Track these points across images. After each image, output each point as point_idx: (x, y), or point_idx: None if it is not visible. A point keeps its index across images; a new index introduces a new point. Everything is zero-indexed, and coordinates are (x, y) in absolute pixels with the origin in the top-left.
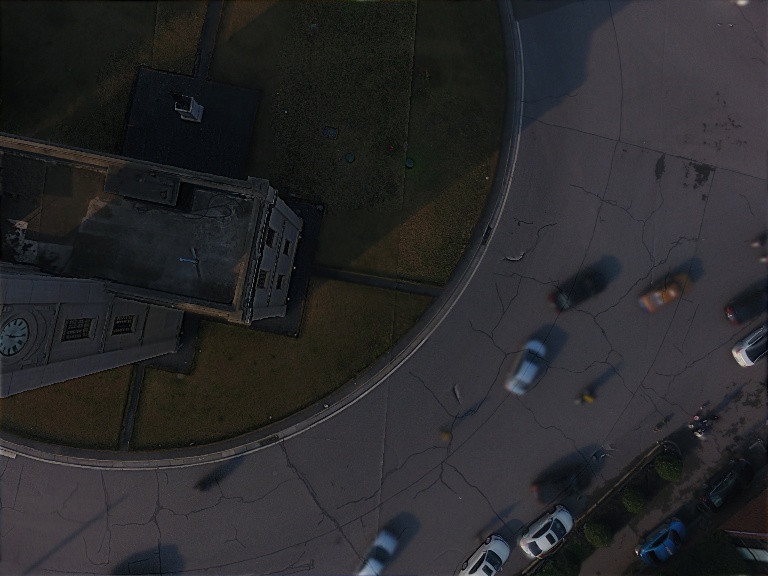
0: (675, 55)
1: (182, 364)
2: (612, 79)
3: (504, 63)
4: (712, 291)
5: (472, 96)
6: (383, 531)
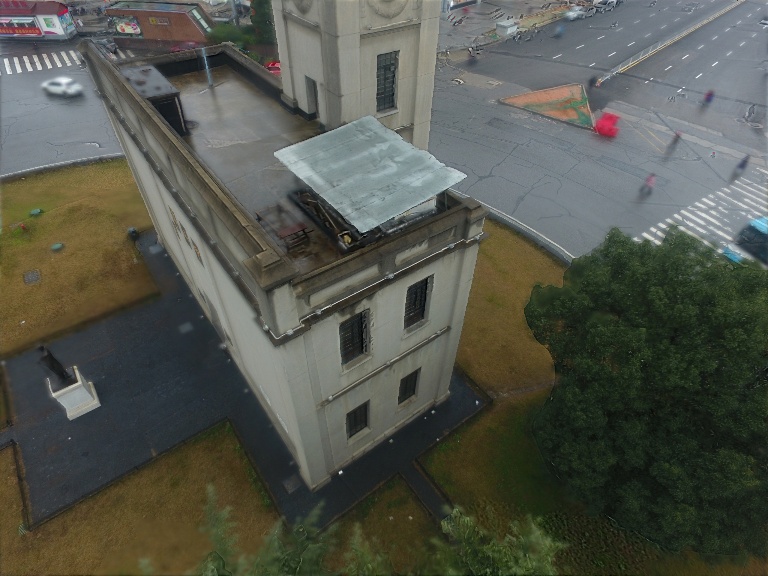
0: None
1: None
2: None
3: None
4: (56, 87)
5: None
6: None
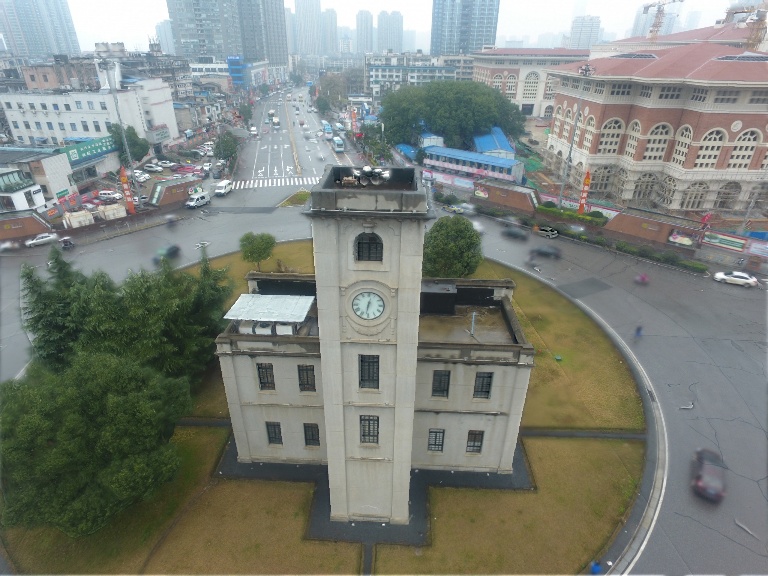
0: (684, 302)
1: (417, 537)
2: (657, 314)
3: (583, 313)
4: None
5: (575, 326)
6: None
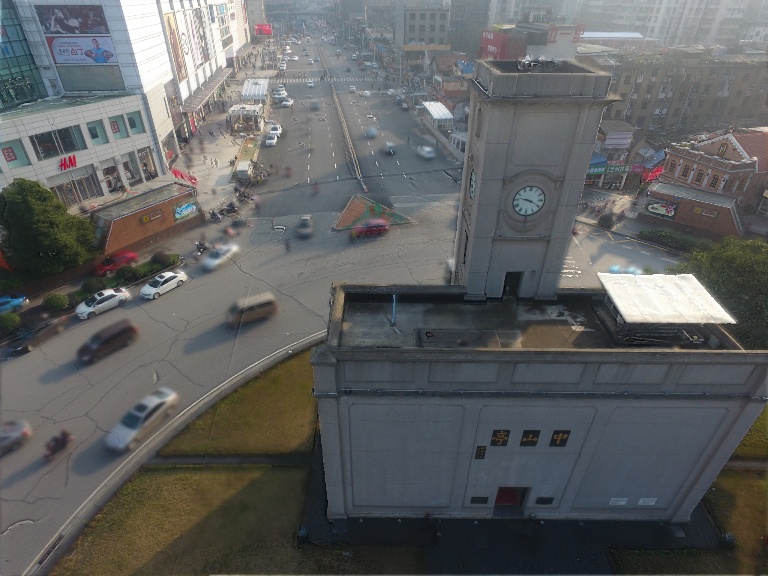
0: None
1: None
2: None
3: None
4: None
5: None
6: (244, 293)
